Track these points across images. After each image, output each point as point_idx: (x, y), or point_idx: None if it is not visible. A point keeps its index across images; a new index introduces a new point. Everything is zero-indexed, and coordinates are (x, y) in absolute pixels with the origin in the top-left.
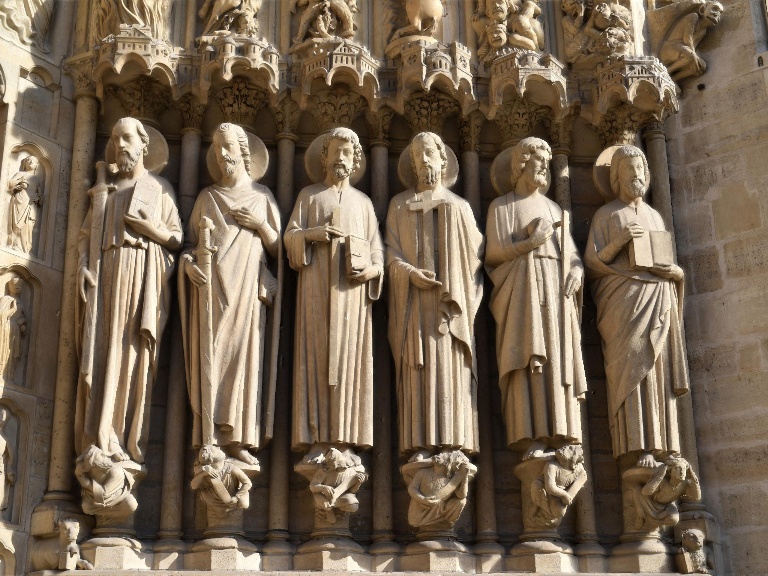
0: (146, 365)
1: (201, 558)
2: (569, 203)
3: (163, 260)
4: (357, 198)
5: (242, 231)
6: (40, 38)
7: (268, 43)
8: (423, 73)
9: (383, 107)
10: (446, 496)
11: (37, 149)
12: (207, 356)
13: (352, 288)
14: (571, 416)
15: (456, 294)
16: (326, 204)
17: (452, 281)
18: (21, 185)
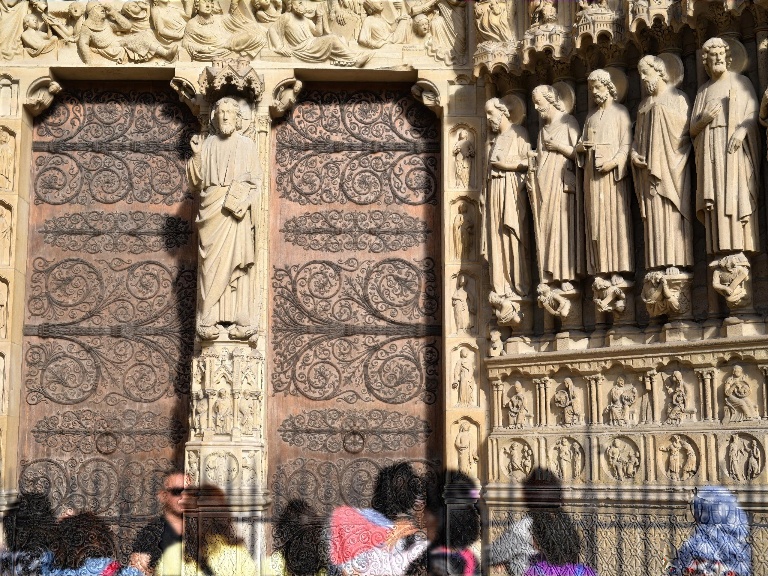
0: (514, 243)
1: (555, 344)
2: (766, 69)
3: (516, 180)
4: (614, 113)
5: (550, 153)
6: (460, 57)
7: (554, 26)
8: (630, 21)
9: (630, 41)
10: (658, 298)
11: (466, 125)
12: (536, 234)
13: (603, 177)
14: (733, 235)
15: (654, 169)
16: (593, 123)
17: (652, 161)
18: (457, 150)
